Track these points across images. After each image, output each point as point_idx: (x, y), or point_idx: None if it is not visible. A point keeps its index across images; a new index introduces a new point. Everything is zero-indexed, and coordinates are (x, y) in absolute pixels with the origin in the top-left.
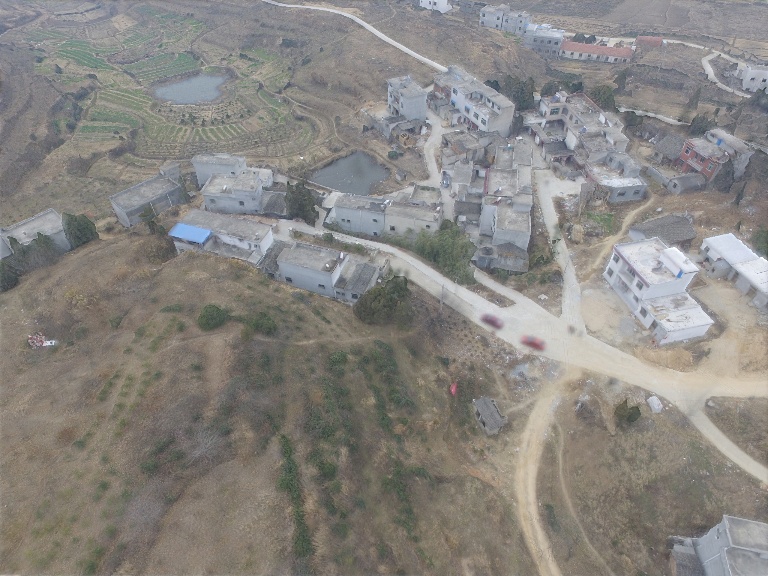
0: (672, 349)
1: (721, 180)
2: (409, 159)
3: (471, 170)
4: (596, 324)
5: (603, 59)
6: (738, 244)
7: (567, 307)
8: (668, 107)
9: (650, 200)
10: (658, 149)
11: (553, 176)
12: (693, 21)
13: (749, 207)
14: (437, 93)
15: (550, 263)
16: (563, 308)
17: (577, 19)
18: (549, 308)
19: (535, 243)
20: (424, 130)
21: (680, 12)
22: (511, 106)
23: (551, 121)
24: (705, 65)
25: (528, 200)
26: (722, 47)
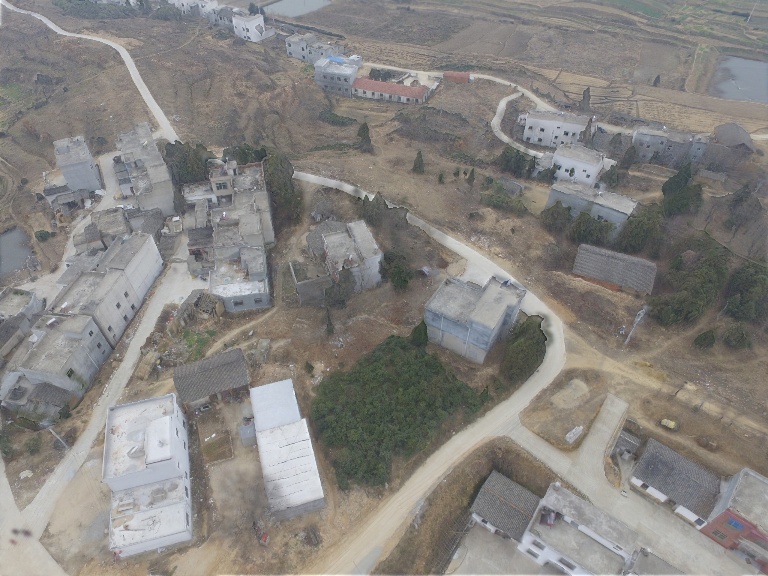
0: (131, 566)
1: (326, 295)
2: (59, 241)
3: (91, 265)
4: (63, 521)
5: (396, 99)
6: (288, 397)
7: (46, 491)
8: (394, 170)
9: (271, 311)
10: (308, 240)
11: (188, 272)
12: (529, 50)
13: (347, 333)
14: (121, 155)
15: (84, 412)
16: (39, 493)
17: (405, 47)
18: (21, 493)
19: (100, 376)
20: (89, 203)
21: (521, 39)
22: (164, 181)
23: (225, 196)
24: (500, 107)
25: (80, 324)
26: (530, 85)
